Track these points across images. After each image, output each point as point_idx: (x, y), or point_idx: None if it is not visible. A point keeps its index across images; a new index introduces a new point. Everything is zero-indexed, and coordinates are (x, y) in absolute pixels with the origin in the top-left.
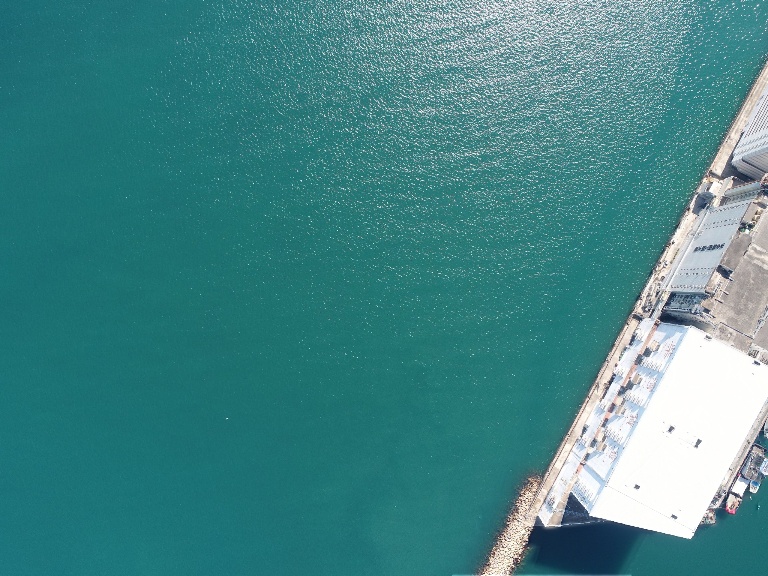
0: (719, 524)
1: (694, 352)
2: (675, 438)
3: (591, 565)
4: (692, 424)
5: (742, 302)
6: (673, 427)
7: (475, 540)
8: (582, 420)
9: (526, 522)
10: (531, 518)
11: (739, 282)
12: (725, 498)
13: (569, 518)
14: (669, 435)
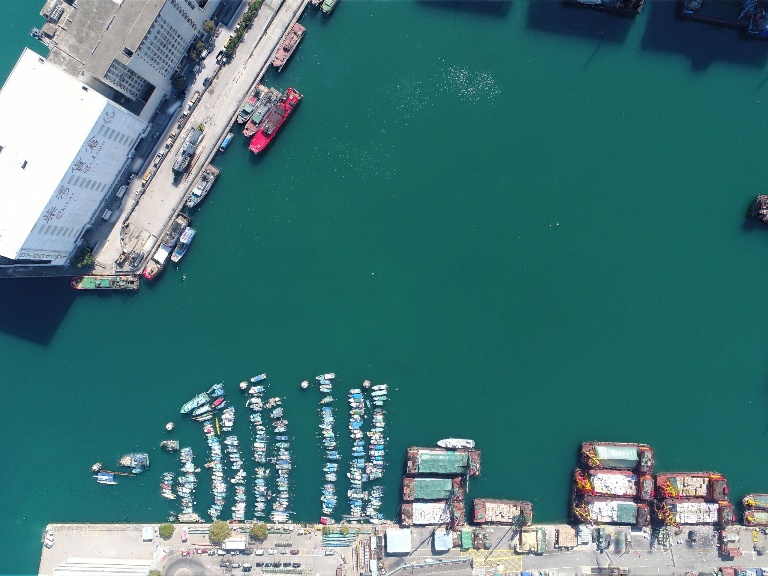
0: (145, 292)
1: (27, 74)
2: (4, 158)
3: (21, 322)
4: (21, 145)
5: (84, 30)
6: (1, 146)
7: None
8: None
9: None
10: None
11: (83, 10)
12: (146, 264)
13: None
14: None
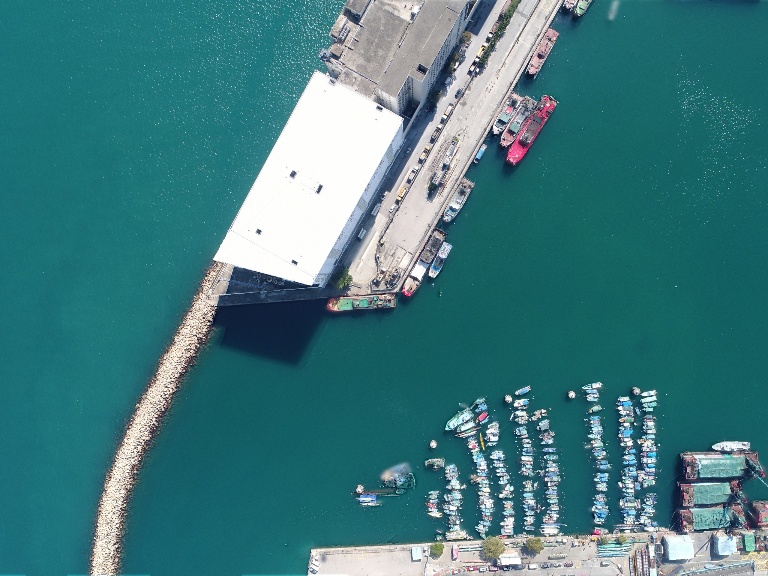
0: (401, 310)
1: (318, 96)
2: (298, 183)
3: (274, 347)
4: (315, 170)
5: (372, 49)
6: (295, 172)
7: (162, 319)
8: None
9: (209, 301)
10: (214, 297)
11: (369, 28)
12: (404, 282)
13: (234, 287)
14: (292, 180)
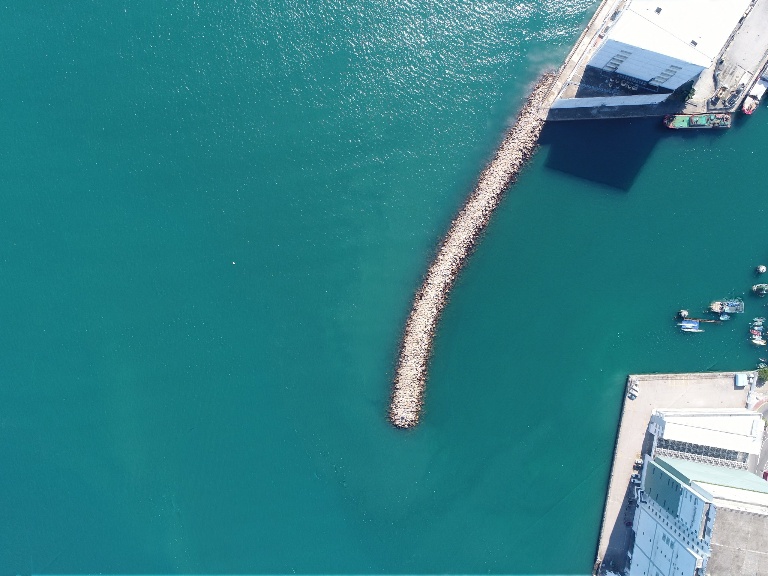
0: (734, 132)
1: None
2: None
3: (600, 166)
4: None
5: None
6: None
7: (485, 133)
8: (603, 13)
9: (538, 115)
10: (543, 111)
11: None
12: (742, 101)
13: (583, 92)
14: None
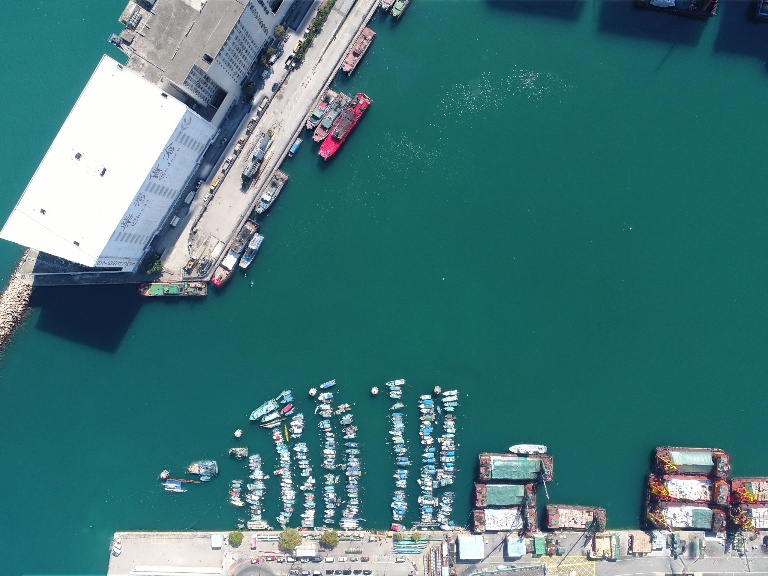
0: (213, 298)
1: (106, 81)
2: (83, 166)
3: (87, 329)
4: (100, 153)
5: (163, 37)
6: (80, 154)
7: None
8: None
9: (24, 280)
10: (30, 277)
11: (161, 16)
12: (215, 270)
13: (40, 267)
14: (77, 162)
